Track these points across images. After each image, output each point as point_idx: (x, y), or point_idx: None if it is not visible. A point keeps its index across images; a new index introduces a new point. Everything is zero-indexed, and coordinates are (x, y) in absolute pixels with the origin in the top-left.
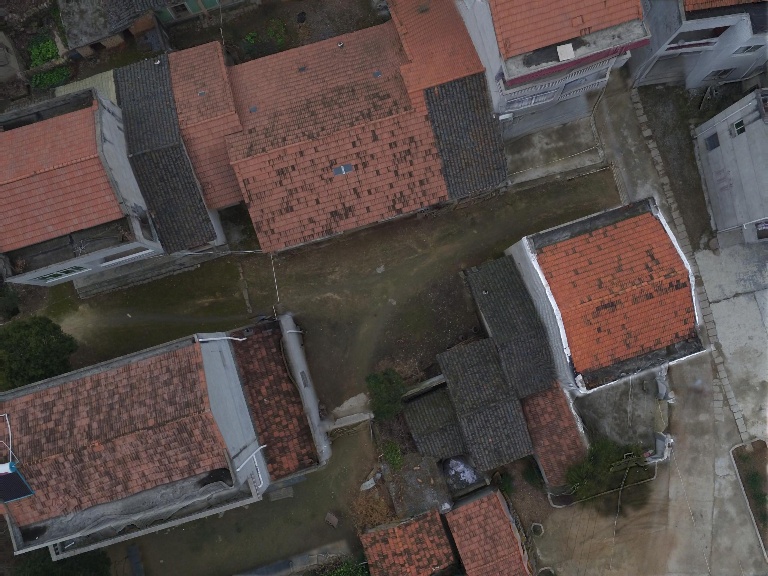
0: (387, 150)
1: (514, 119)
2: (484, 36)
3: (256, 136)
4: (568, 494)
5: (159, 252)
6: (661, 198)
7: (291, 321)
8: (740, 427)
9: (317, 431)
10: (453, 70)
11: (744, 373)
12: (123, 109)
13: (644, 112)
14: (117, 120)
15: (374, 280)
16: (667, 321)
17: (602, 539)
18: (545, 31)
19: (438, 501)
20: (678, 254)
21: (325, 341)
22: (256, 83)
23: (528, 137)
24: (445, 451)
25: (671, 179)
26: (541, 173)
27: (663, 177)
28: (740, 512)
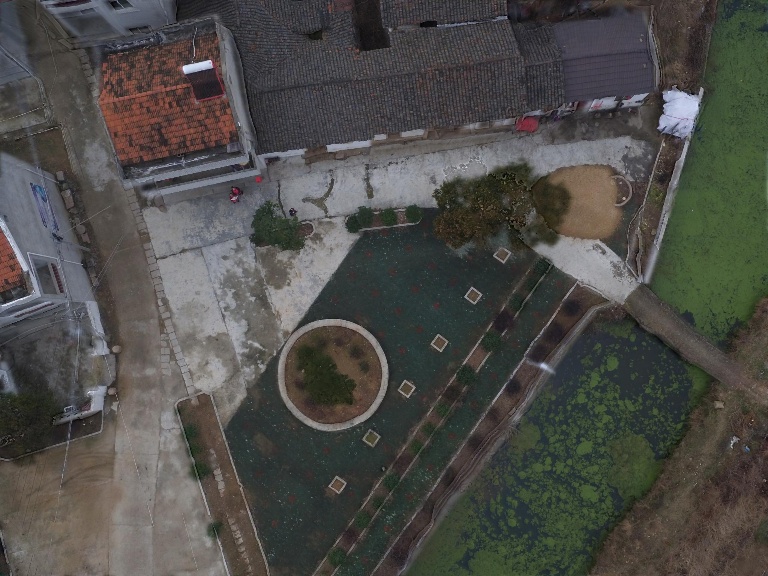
0: None
1: None
2: None
3: None
4: (0, 446)
5: None
6: (109, 157)
7: None
8: (186, 381)
9: None
10: None
11: (191, 328)
12: None
13: (93, 73)
14: None
15: None
16: None
17: (48, 492)
18: None
19: None
20: None
21: None
22: None
23: None
24: None
25: None
26: None
27: None
28: (184, 465)
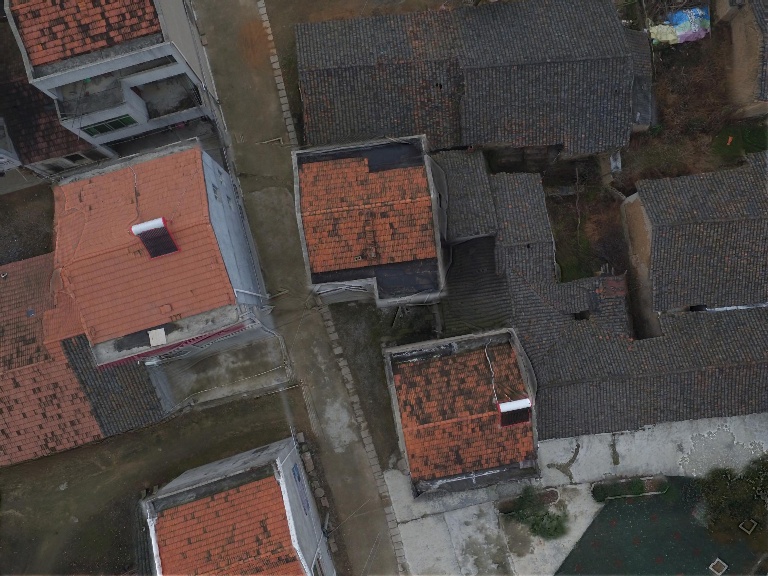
0: (31, 395)
1: (160, 365)
2: None
3: None
4: None
5: None
6: (350, 417)
7: None
8: None
9: None
10: None
11: None
12: None
13: (335, 329)
14: None
15: (57, 497)
16: None
17: None
18: (132, 319)
19: None
20: (288, 528)
21: (5, 559)
22: None
23: (212, 357)
24: None
25: (361, 397)
26: (226, 392)
27: (353, 395)
28: None
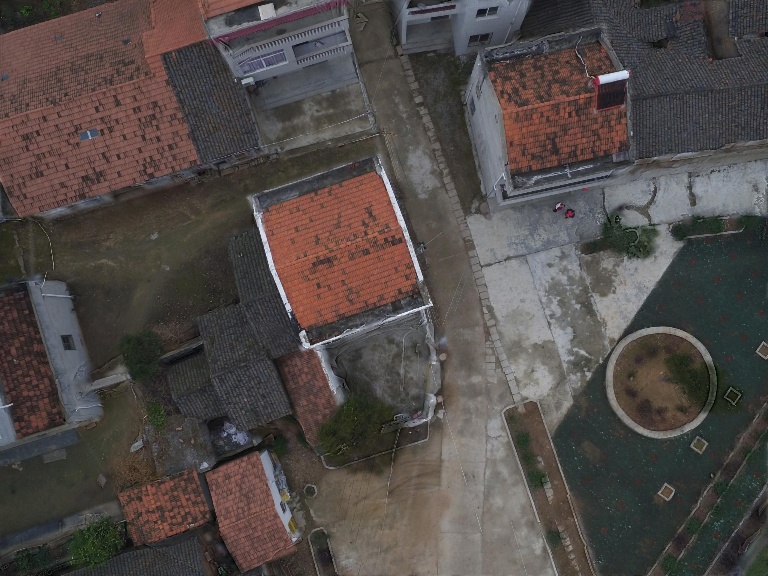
0: (131, 115)
1: (256, 83)
2: None
3: (3, 102)
4: (335, 455)
5: None
6: (432, 163)
7: (62, 286)
8: (512, 389)
9: (66, 390)
10: (190, 35)
11: (516, 335)
12: None
13: (415, 79)
14: None
15: (148, 246)
16: (388, 277)
17: (375, 500)
18: None
19: (197, 460)
20: (393, 210)
21: (98, 306)
22: (13, 52)
23: (297, 104)
24: (208, 412)
25: (443, 145)
26: (311, 140)
27: (435, 143)
28: (512, 473)
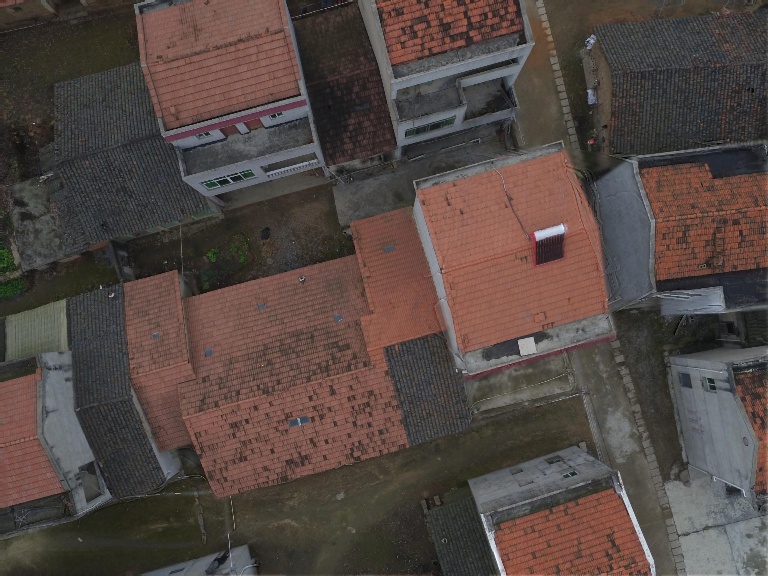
0: (345, 403)
1: None
2: (444, 315)
3: (210, 386)
4: None
5: (108, 499)
6: (632, 427)
7: (246, 552)
8: None
9: None
10: (415, 328)
11: None
12: (73, 350)
13: (617, 337)
14: (65, 371)
15: (333, 507)
16: None
17: None
18: (505, 327)
19: None
20: (640, 542)
21: (281, 570)
22: (213, 320)
23: None
24: None
25: (643, 407)
26: (509, 400)
27: (635, 405)
28: None
